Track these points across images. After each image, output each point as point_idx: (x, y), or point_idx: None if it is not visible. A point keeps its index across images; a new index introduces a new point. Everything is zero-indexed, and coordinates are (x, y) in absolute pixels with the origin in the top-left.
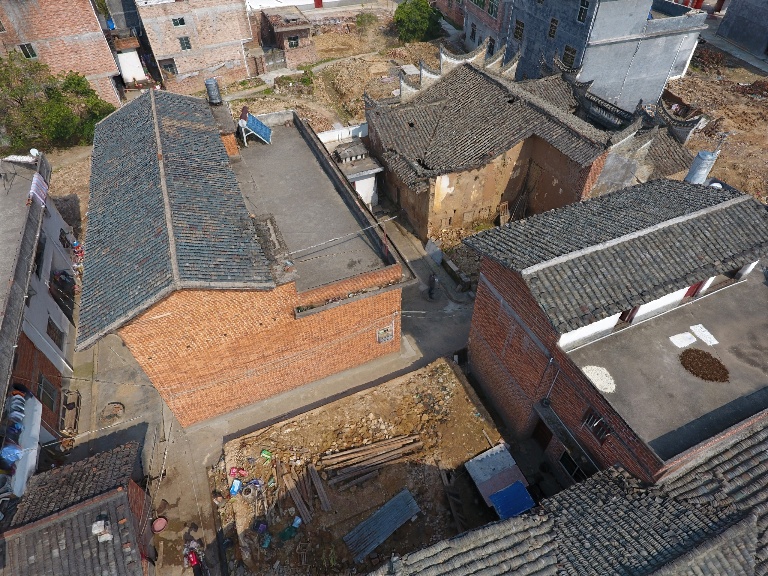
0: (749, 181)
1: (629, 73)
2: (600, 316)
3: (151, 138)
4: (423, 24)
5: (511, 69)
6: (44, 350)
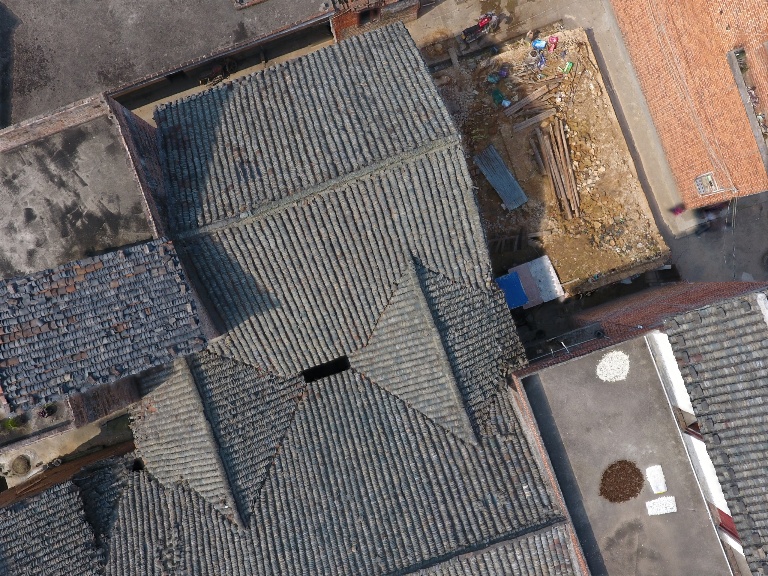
0: None
1: None
2: (686, 372)
3: None
4: None
5: None
6: None
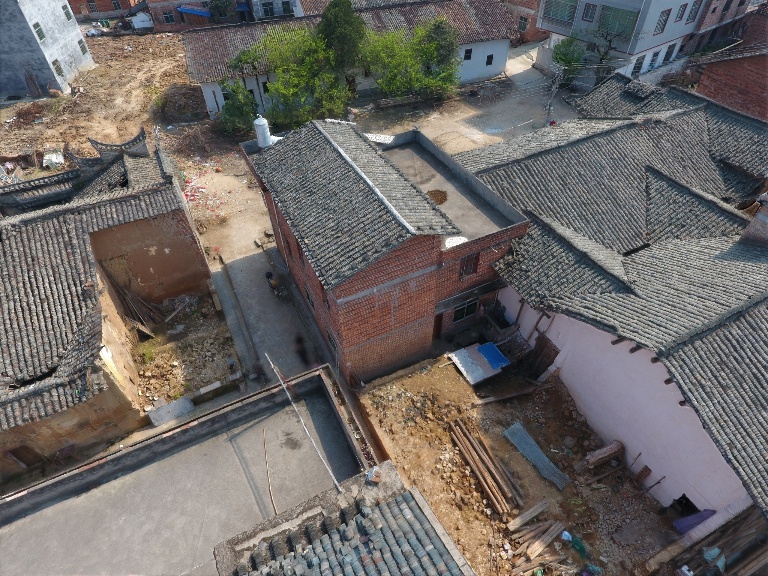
0: None
1: None
2: None
3: None
4: None
5: None
6: None
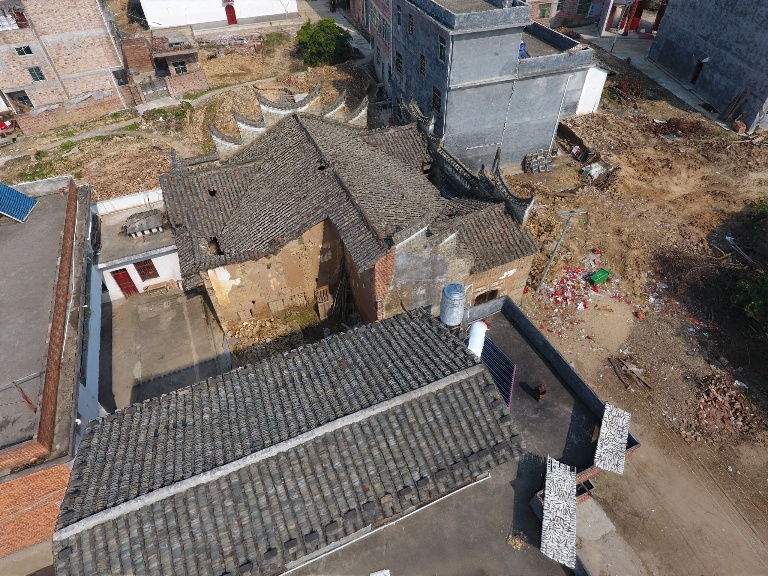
0: (630, 252)
1: (509, 117)
2: None
3: None
4: (329, 46)
5: (360, 117)
6: None
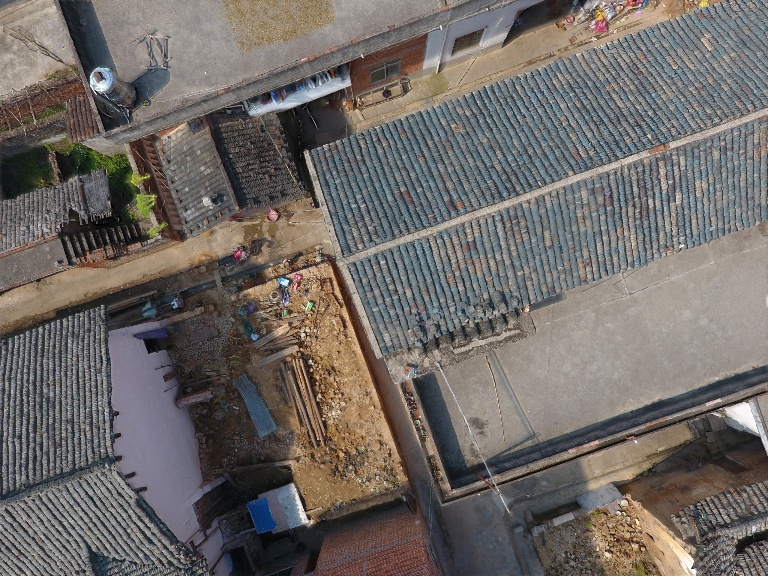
0: None
1: None
2: None
3: (744, 106)
4: None
5: None
6: (432, 48)
